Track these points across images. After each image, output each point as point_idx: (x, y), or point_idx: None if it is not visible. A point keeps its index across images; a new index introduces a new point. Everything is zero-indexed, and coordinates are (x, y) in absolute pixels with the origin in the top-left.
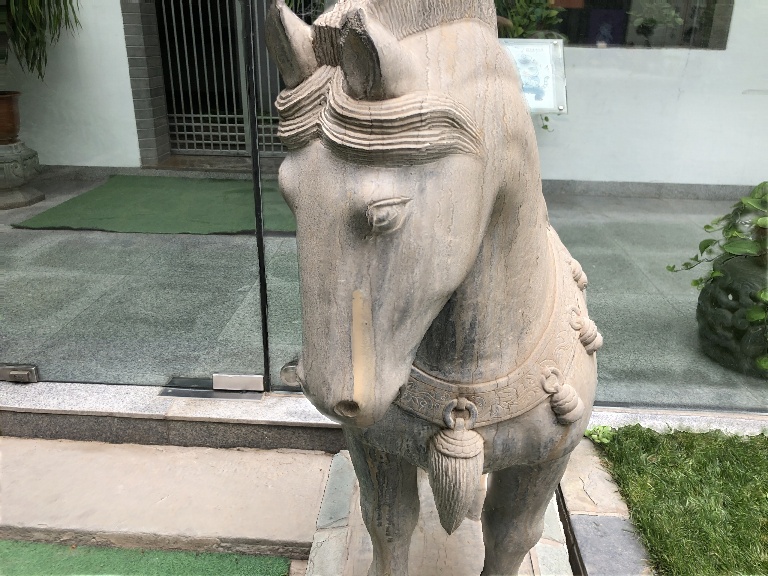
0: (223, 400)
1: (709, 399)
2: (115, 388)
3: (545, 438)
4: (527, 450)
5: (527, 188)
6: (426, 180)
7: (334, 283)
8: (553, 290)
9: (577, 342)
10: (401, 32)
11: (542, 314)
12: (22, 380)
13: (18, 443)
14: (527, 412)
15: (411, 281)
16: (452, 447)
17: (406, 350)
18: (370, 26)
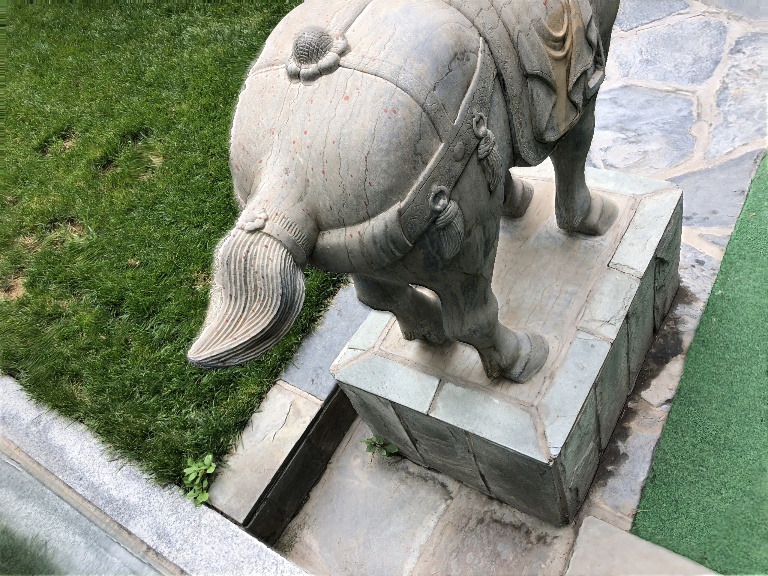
0: None
1: (20, 512)
2: None
3: None
4: None
5: None
6: None
7: None
8: None
9: None
10: None
11: None
12: None
13: None
14: None
15: None
16: None
17: None
18: None
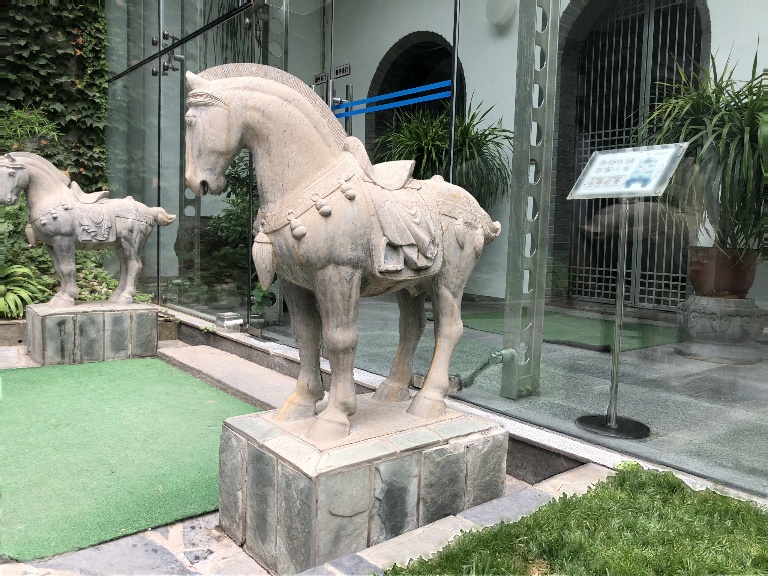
0: (411, 390)
1: None
2: (369, 374)
3: None
4: None
5: (270, 130)
6: (201, 111)
7: None
8: (308, 183)
9: (313, 206)
10: (214, 79)
11: (296, 190)
12: None
13: None
14: (282, 229)
15: (199, 141)
16: None
17: (205, 167)
18: None
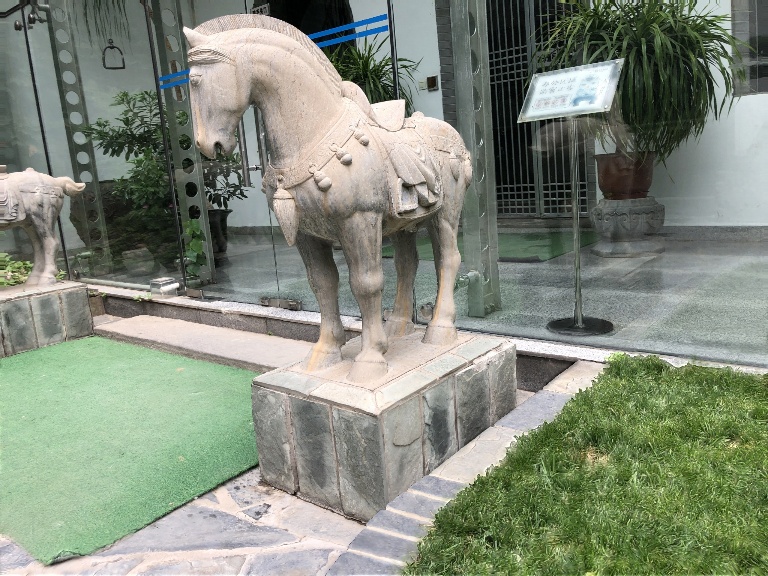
0: None
1: None
2: None
3: (316, 197)
4: (314, 205)
5: (279, 83)
6: (207, 70)
7: (191, 103)
8: (323, 134)
9: (333, 156)
10: (211, 33)
11: (313, 141)
12: (294, 308)
13: (282, 339)
14: (305, 182)
15: (208, 101)
16: (275, 194)
17: (217, 128)
18: (184, 30)
